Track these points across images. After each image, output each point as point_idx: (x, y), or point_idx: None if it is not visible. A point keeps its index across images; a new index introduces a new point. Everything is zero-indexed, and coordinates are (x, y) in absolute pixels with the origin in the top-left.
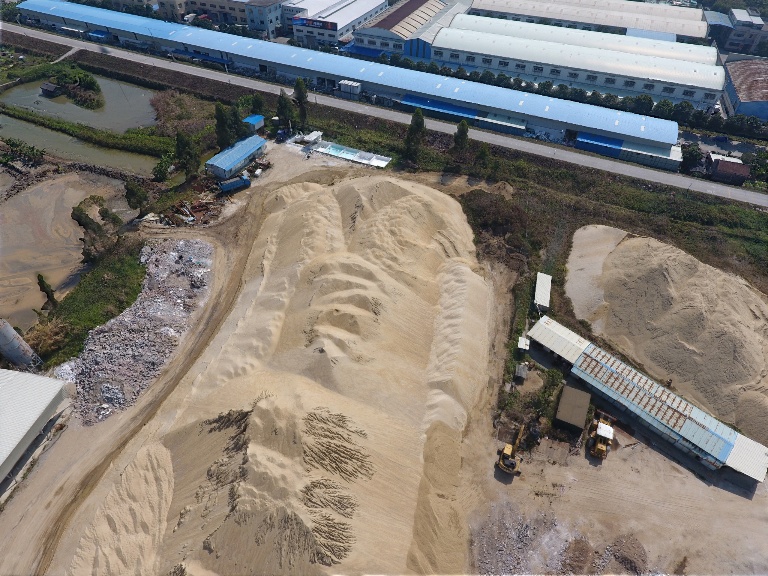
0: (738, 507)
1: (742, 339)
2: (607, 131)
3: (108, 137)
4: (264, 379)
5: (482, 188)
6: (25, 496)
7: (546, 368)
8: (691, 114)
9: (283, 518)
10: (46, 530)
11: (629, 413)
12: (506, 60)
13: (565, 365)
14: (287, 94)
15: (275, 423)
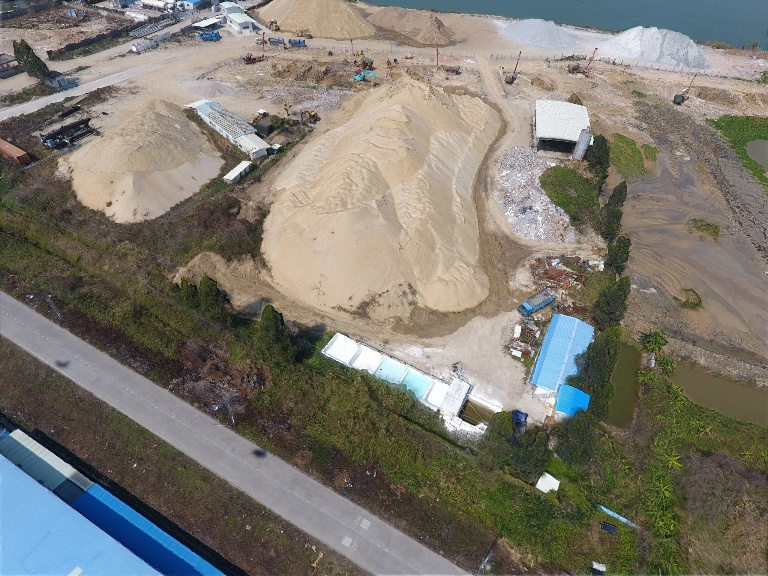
0: None
1: None
2: None
3: None
4: (432, 118)
5: None
6: None
7: None
8: None
9: None
10: None
11: None
12: None
13: None
14: None
15: None
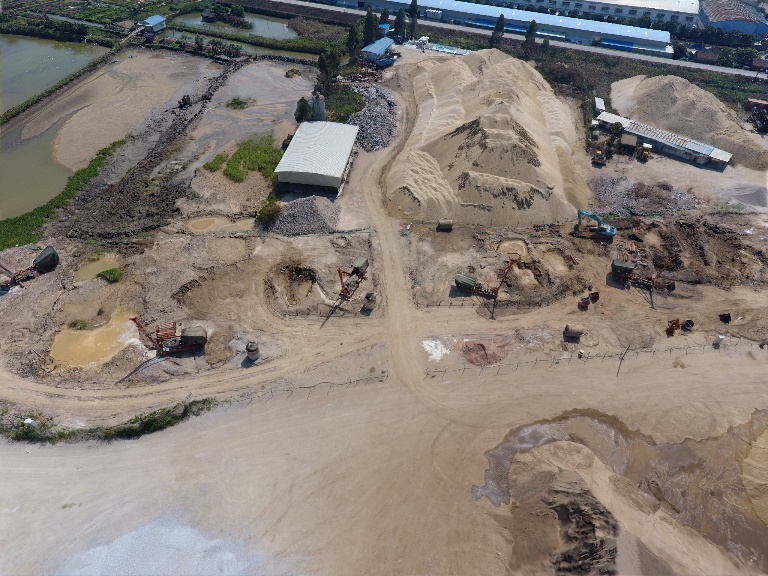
0: (716, 174)
1: (716, 111)
2: (623, 36)
3: (277, 42)
4: None
5: None
6: (357, 172)
7: (609, 134)
8: (677, 28)
9: (512, 146)
10: (376, 181)
11: (657, 147)
12: None
13: None
14: None
15: (495, 119)
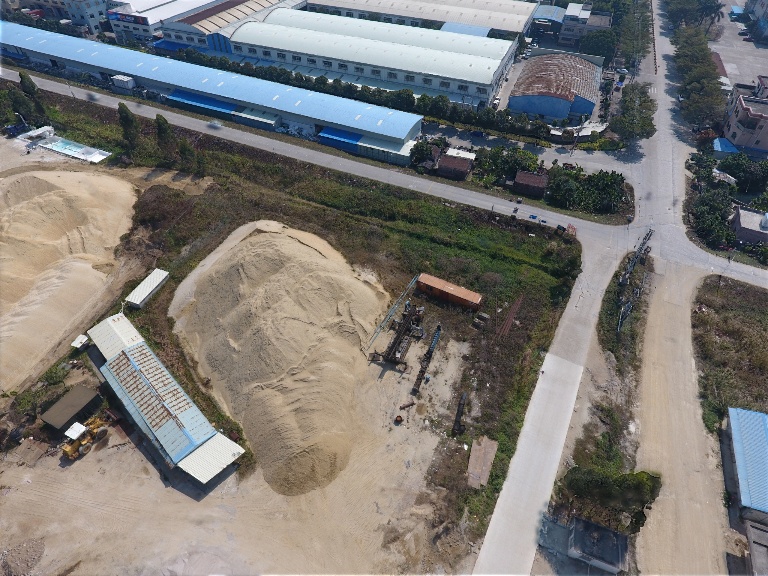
0: (179, 509)
1: (274, 336)
2: (345, 126)
3: None
4: None
5: (183, 183)
6: None
7: (95, 366)
8: (449, 109)
9: None
10: None
11: None
12: (297, 55)
13: None
14: None
15: None
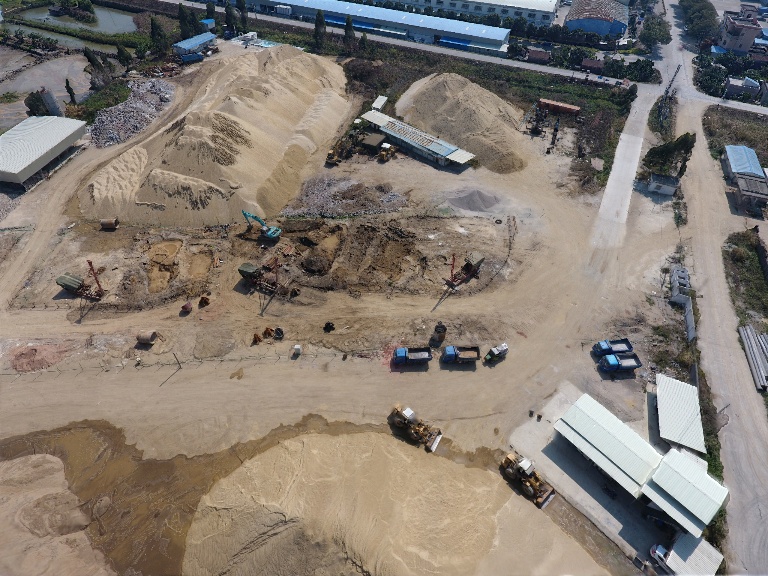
0: (449, 176)
1: (476, 110)
2: (459, 33)
3: (102, 36)
4: None
5: None
6: (68, 168)
7: (370, 133)
8: (526, 27)
9: (200, 144)
10: (80, 178)
11: (408, 148)
12: None
13: (380, 131)
14: (232, 6)
15: (199, 115)
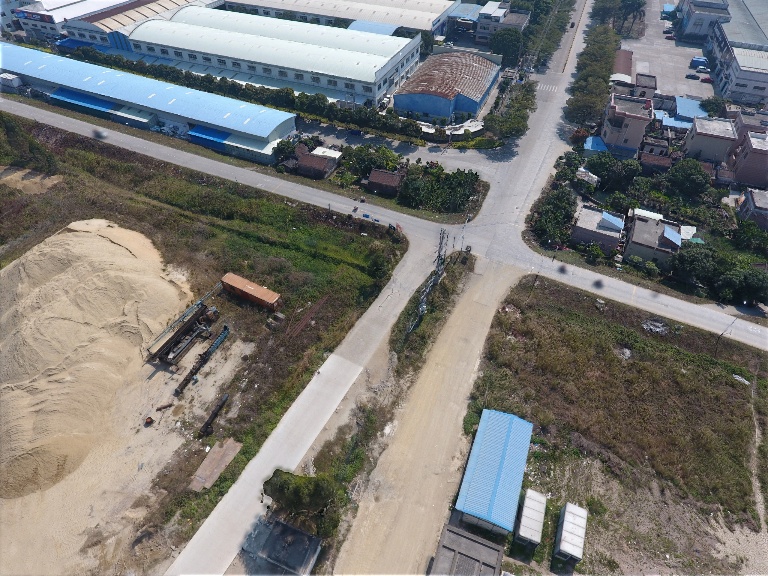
0: None
1: (32, 336)
2: (212, 124)
3: None
4: None
5: (30, 182)
6: None
7: None
8: None
9: None
10: None
11: None
12: (193, 53)
13: None
14: None
15: None
